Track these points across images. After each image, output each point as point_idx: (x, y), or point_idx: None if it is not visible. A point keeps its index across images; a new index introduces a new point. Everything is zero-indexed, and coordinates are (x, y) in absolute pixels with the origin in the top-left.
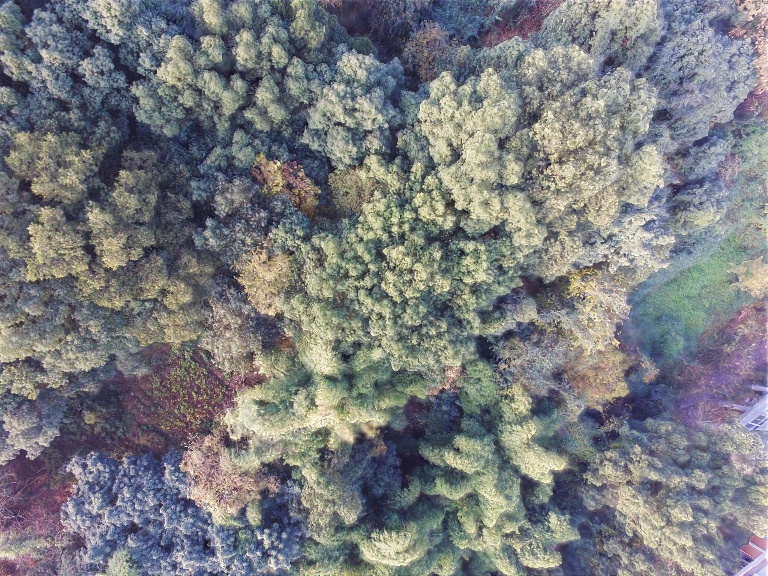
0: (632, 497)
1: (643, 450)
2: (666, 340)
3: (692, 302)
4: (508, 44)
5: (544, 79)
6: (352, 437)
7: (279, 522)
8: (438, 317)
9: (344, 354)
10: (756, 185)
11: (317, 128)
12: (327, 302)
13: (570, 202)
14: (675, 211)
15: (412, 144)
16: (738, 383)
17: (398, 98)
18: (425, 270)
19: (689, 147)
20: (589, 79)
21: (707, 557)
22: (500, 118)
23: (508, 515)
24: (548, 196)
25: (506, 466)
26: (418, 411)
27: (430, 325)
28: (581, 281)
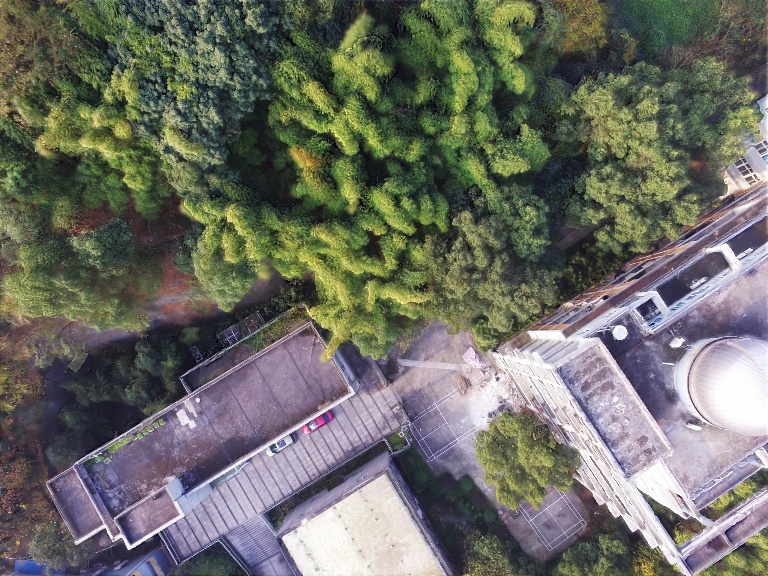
0: (601, 95)
1: None
2: (648, 35)
3: (675, 6)
4: None
5: None
6: None
7: None
8: None
9: None
10: None
11: None
12: None
13: None
14: None
15: None
16: None
17: None
18: None
19: None
20: None
21: (672, 155)
22: None
23: None
24: None
25: (480, 50)
26: (399, 2)
27: None
28: None
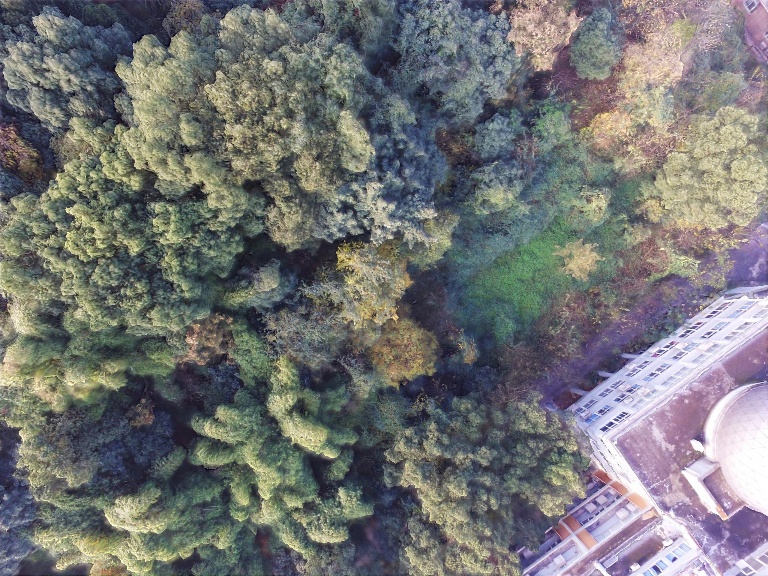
0: (412, 472)
1: (441, 428)
2: (496, 322)
3: (525, 285)
4: (234, 12)
5: (245, 43)
6: (104, 404)
7: (9, 485)
8: (141, 279)
9: (50, 315)
10: (574, 167)
11: (15, 89)
12: (20, 261)
13: (259, 164)
14: (474, 189)
15: (123, 108)
16: (565, 366)
17: (113, 62)
18: (100, 228)
19: (474, 124)
20: (287, 44)
21: (486, 533)
22: (170, 77)
23: (293, 489)
24: (231, 157)
25: (282, 439)
26: (199, 383)
27: (130, 286)
28: (346, 253)
